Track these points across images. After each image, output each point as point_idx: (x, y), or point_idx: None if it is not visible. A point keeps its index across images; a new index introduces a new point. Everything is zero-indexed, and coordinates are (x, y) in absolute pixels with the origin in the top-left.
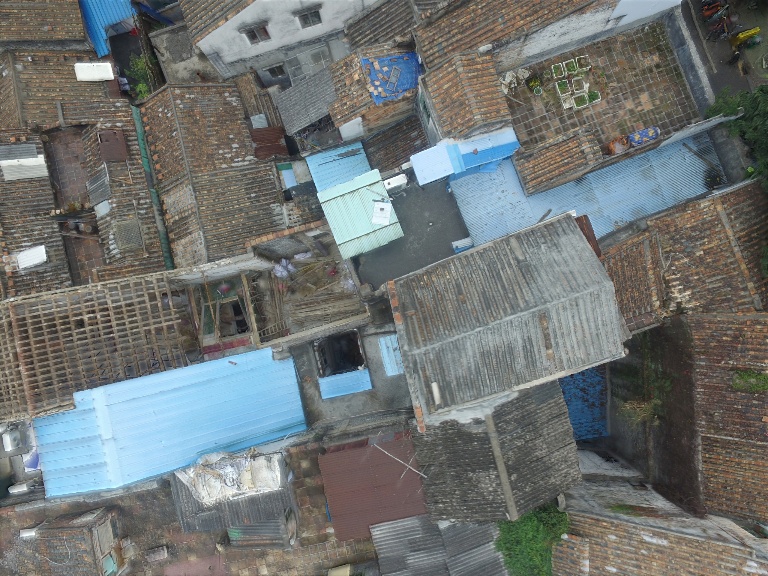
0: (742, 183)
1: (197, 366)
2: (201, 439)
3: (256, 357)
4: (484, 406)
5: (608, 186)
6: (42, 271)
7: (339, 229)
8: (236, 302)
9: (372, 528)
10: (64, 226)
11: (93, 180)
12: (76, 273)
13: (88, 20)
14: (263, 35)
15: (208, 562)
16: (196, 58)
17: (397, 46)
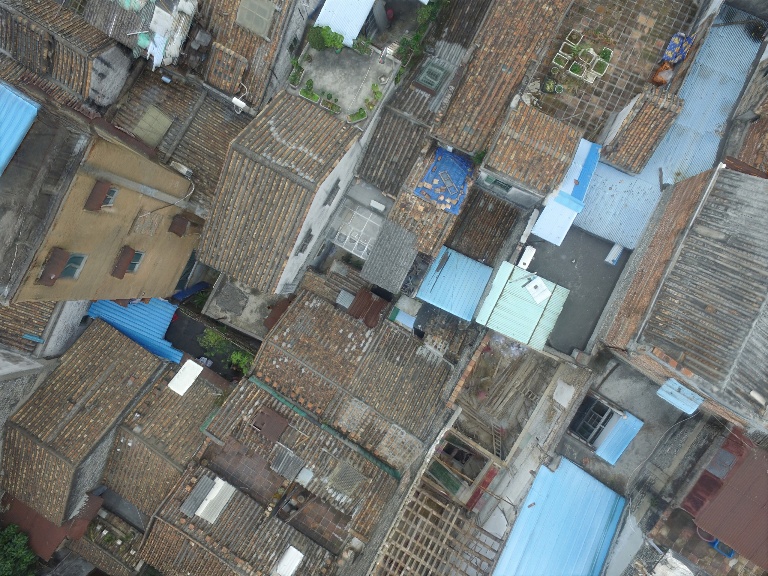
0: None
1: (513, 534)
2: None
3: (541, 483)
4: None
5: (684, 110)
6: (302, 565)
7: (517, 332)
8: (448, 446)
9: None
10: (279, 514)
11: (276, 462)
12: (321, 540)
13: (146, 344)
14: (307, 239)
15: None
16: (252, 296)
17: (425, 156)
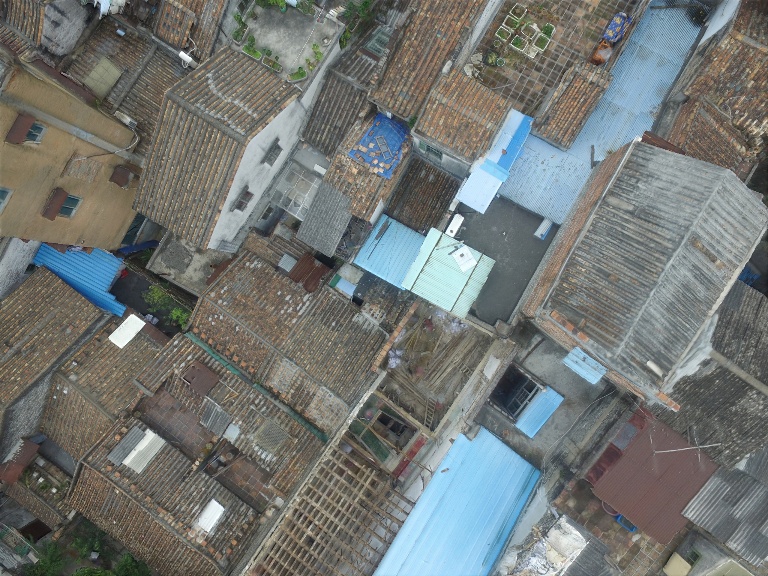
0: (729, 1)
1: (423, 497)
2: (475, 551)
3: (457, 450)
4: (702, 347)
5: (621, 90)
6: (224, 519)
7: (441, 298)
8: (382, 415)
9: (685, 513)
10: (208, 469)
11: (205, 416)
12: (247, 498)
13: (90, 296)
14: (246, 197)
15: None
16: (197, 255)
17: (364, 120)
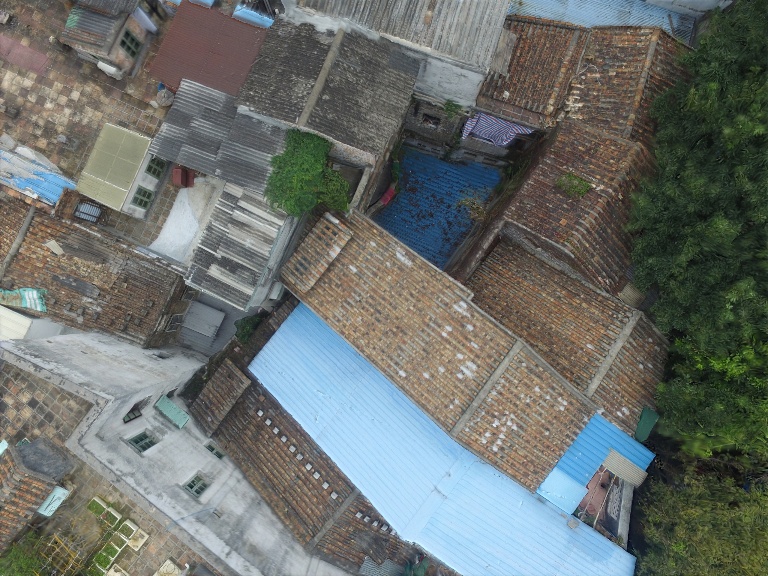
0: None
1: None
2: None
3: None
4: (344, 19)
5: (583, 2)
6: None
7: None
8: None
9: (184, 81)
10: None
11: None
12: None
13: None
14: None
15: (35, 57)
16: None
17: None
